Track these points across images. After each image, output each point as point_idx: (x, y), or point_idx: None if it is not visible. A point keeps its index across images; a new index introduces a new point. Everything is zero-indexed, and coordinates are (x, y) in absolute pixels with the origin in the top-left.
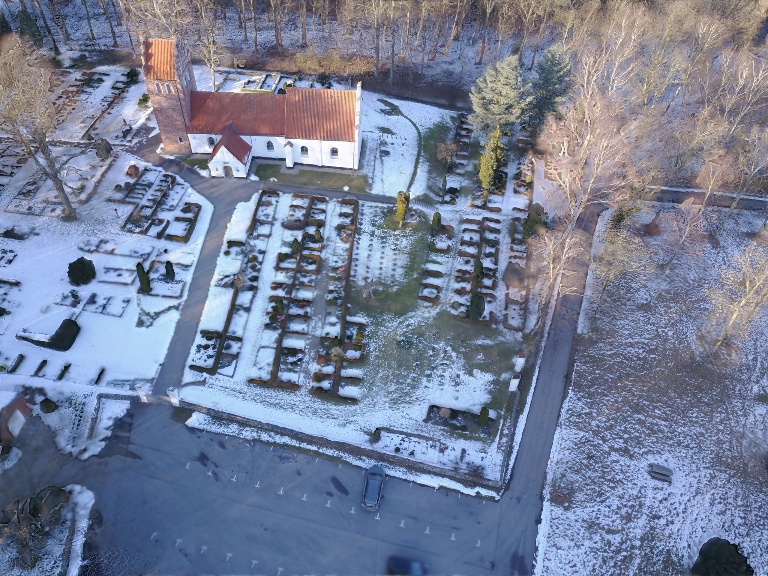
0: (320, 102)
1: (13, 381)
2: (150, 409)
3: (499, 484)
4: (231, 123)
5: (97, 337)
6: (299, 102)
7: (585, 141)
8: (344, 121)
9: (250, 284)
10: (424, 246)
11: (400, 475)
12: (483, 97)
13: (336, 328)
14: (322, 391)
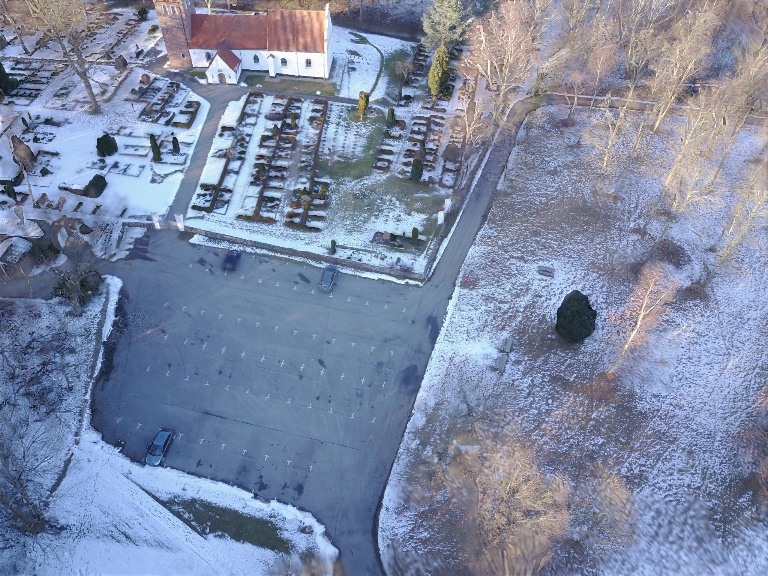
0: (295, 21)
1: None
2: (162, 233)
3: (423, 276)
4: (224, 40)
5: (120, 189)
6: (279, 21)
7: None
8: (315, 36)
9: (239, 156)
10: (380, 133)
11: (349, 272)
12: (432, 21)
13: (306, 185)
14: (293, 223)
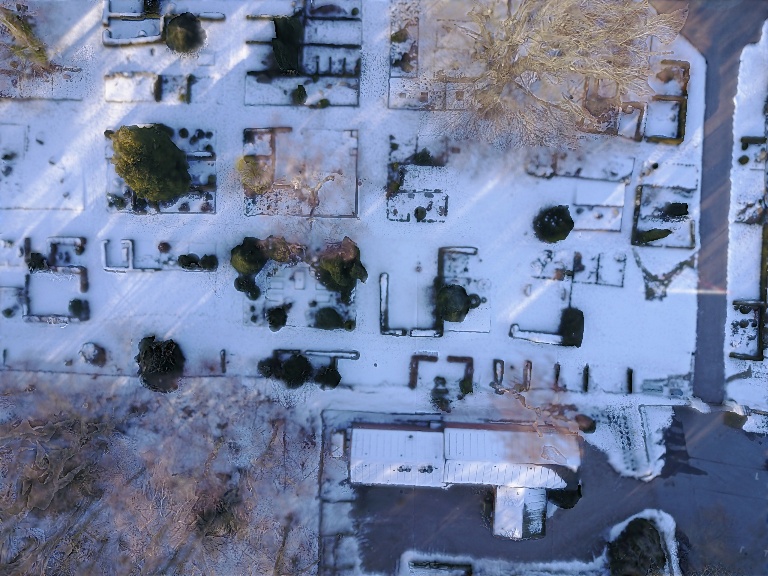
0: None
1: (537, 400)
2: (698, 414)
3: None
4: None
5: (604, 322)
6: None
7: None
8: None
9: None
10: None
11: None
12: None
13: None
14: None
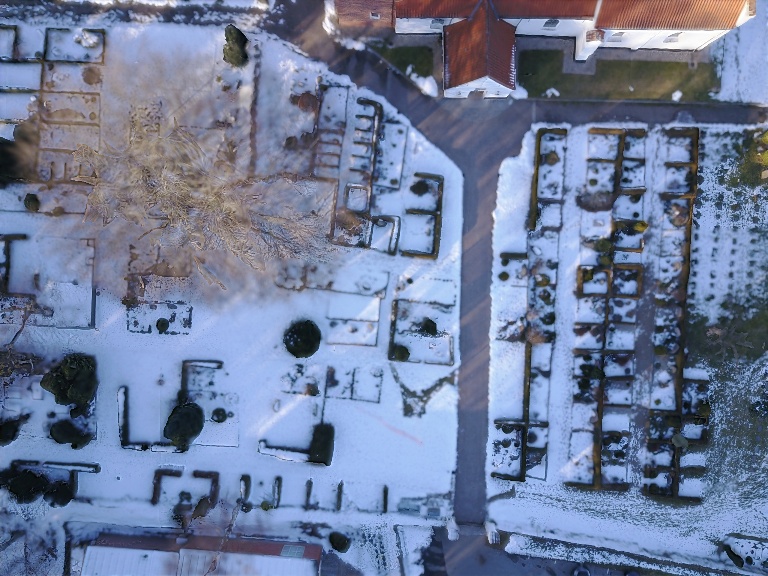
0: None
1: (286, 518)
2: None
3: None
4: None
5: (360, 438)
6: None
7: None
8: None
9: (545, 330)
10: None
11: None
12: None
13: (669, 390)
14: (658, 491)
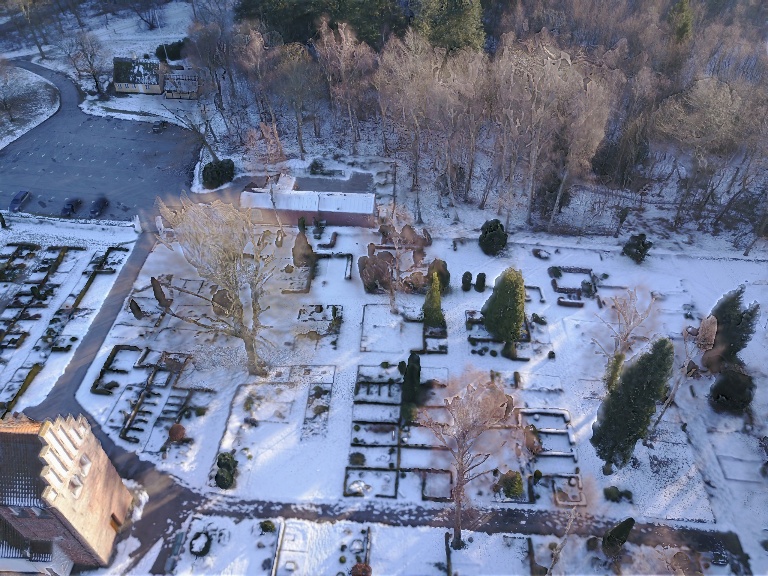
0: None
1: (258, 230)
2: None
3: None
4: None
5: None
6: None
7: None
8: None
9: (60, 315)
10: None
11: (1, 211)
12: None
13: None
14: None
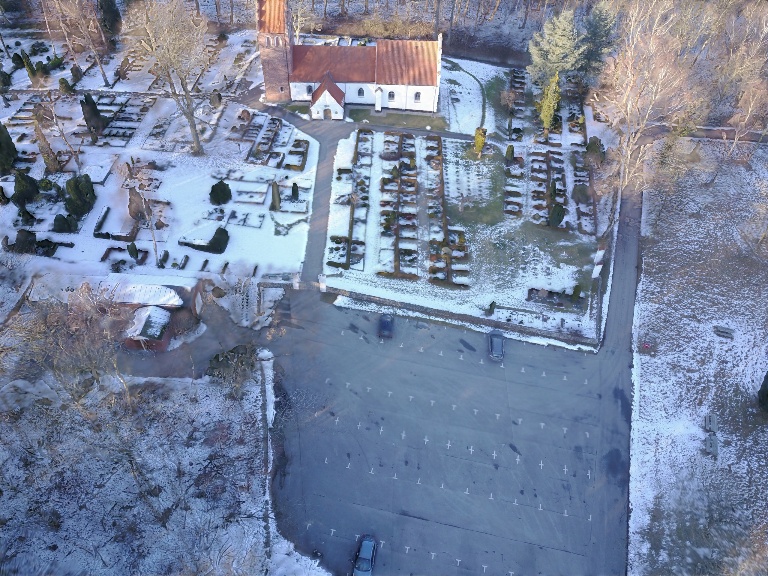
0: (406, 52)
1: (186, 275)
2: (302, 294)
3: (596, 341)
4: (328, 72)
5: (244, 243)
6: (388, 52)
7: (628, 87)
8: (427, 68)
9: (363, 202)
10: (502, 173)
11: (515, 337)
12: (540, 49)
13: (440, 235)
14: (439, 280)
